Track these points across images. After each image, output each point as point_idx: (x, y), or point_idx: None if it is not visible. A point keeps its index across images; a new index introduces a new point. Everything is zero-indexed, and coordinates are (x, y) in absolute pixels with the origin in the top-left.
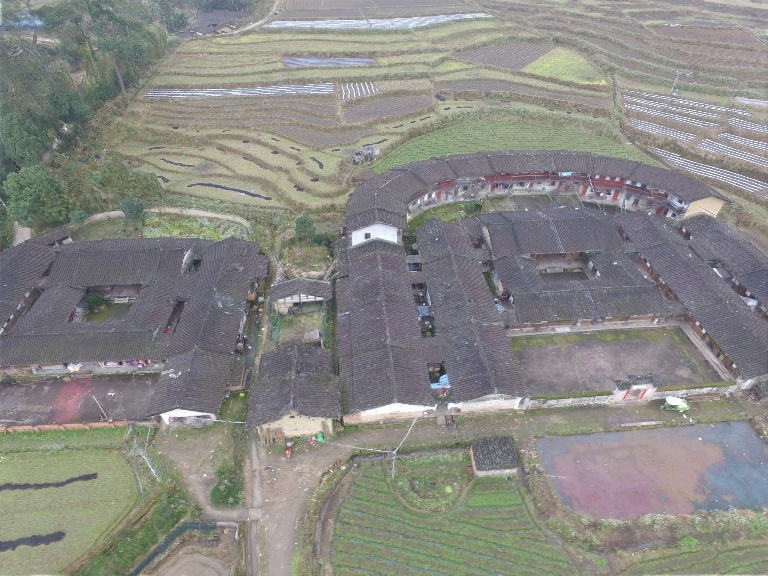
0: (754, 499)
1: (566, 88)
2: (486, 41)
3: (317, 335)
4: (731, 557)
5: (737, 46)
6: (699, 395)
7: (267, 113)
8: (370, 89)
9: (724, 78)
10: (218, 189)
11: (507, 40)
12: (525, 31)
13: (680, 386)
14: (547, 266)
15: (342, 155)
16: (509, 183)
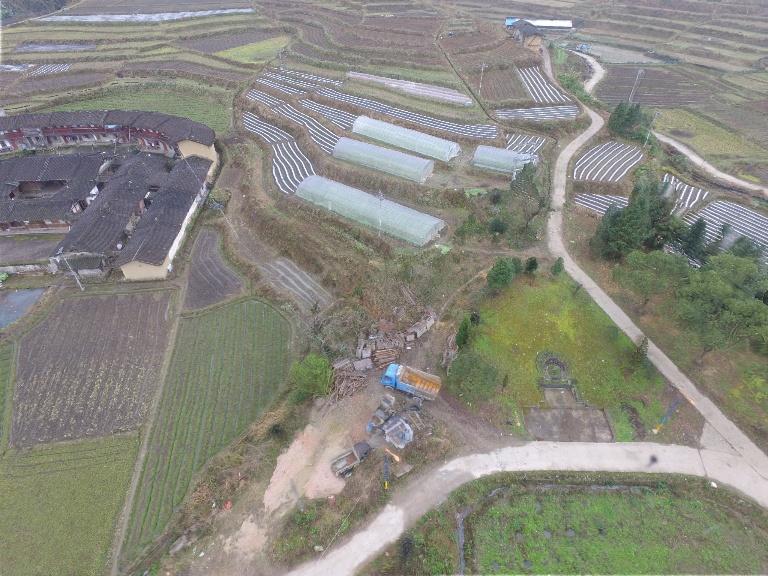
0: None
1: (229, 67)
2: (219, 31)
3: None
4: None
5: (411, 32)
6: (28, 272)
7: None
8: (63, 68)
9: (355, 57)
10: None
11: (245, 31)
12: (268, 23)
13: (5, 263)
14: (44, 194)
15: None
16: (75, 135)
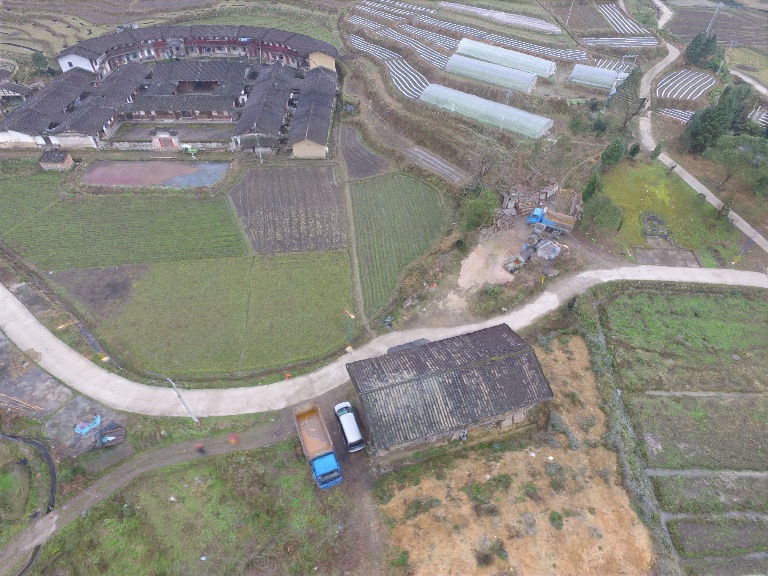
0: (189, 186)
1: None
2: None
3: (5, 111)
4: (142, 199)
5: None
6: (212, 149)
7: (81, 3)
8: None
9: None
10: (12, 46)
11: None
12: None
13: (196, 140)
14: (197, 94)
15: (110, 28)
16: (210, 47)
